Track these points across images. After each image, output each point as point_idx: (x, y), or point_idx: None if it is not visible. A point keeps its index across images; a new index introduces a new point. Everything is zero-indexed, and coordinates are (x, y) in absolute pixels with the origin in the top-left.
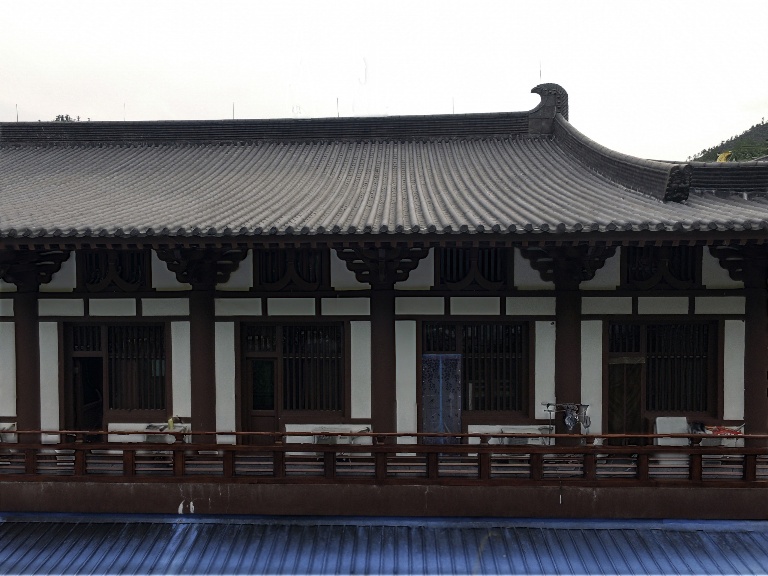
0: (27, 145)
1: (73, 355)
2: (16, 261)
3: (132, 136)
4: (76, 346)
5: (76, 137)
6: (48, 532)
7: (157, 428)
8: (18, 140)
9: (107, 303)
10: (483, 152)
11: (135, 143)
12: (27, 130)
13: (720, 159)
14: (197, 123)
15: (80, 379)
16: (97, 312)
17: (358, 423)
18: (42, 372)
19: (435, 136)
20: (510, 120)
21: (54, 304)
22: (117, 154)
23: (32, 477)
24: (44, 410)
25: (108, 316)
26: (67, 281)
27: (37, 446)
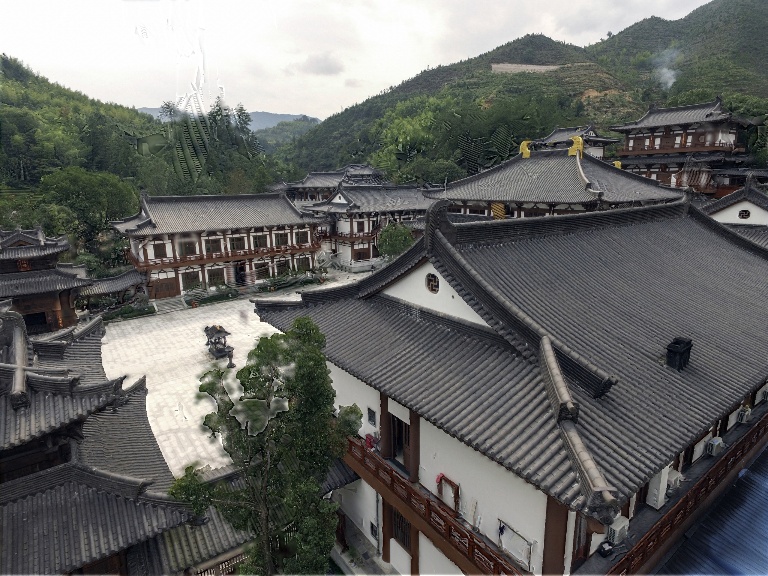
0: (506, 241)
1: None
2: None
3: (559, 228)
4: None
5: (533, 231)
6: (761, 464)
7: None
8: (501, 237)
9: None
10: (686, 230)
11: (560, 233)
12: (507, 228)
13: (523, 144)
14: (586, 216)
15: None
16: None
17: (766, 383)
18: None
19: (661, 218)
20: (680, 207)
21: None
22: (568, 246)
23: (751, 447)
24: None
25: None
26: None
27: None
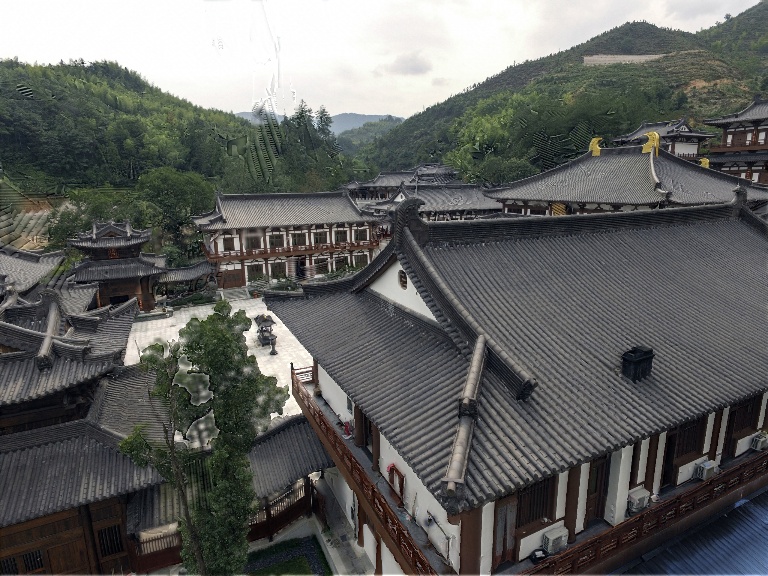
0: (490, 240)
1: None
2: None
3: (557, 229)
4: None
5: (523, 232)
6: None
7: (762, 437)
8: (483, 237)
9: None
10: (730, 235)
11: (558, 234)
12: (490, 228)
13: (593, 141)
14: (594, 217)
15: None
16: None
17: None
18: (721, 425)
19: (698, 220)
20: (726, 209)
21: None
22: (564, 248)
23: None
24: (719, 444)
25: None
26: None
27: None
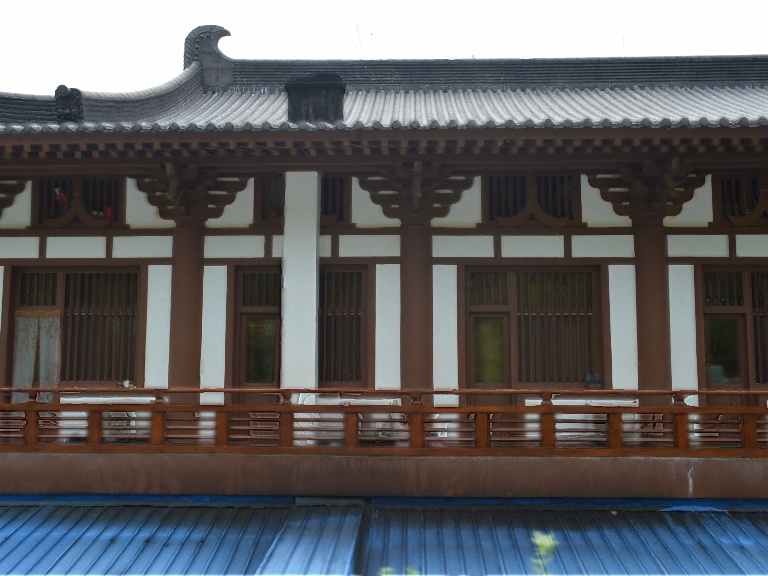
0: None
1: (705, 311)
2: (674, 180)
3: (488, 78)
4: (708, 299)
5: (412, 79)
6: None
7: None
8: None
9: (761, 240)
10: None
11: (493, 87)
12: (344, 69)
13: None
14: (577, 61)
15: (705, 345)
16: (747, 252)
17: None
18: (673, 331)
19: None
20: None
21: (690, 241)
22: (486, 98)
23: (755, 452)
24: (677, 382)
25: (763, 257)
26: (700, 213)
27: (760, 410)
